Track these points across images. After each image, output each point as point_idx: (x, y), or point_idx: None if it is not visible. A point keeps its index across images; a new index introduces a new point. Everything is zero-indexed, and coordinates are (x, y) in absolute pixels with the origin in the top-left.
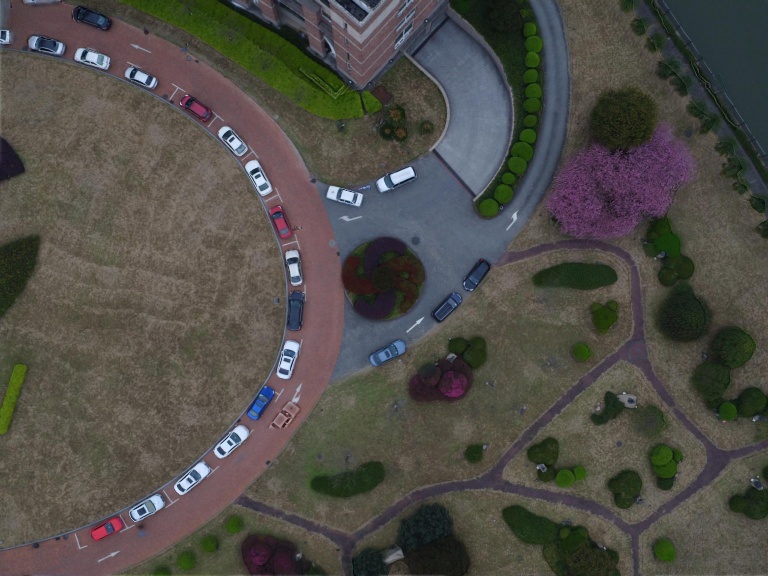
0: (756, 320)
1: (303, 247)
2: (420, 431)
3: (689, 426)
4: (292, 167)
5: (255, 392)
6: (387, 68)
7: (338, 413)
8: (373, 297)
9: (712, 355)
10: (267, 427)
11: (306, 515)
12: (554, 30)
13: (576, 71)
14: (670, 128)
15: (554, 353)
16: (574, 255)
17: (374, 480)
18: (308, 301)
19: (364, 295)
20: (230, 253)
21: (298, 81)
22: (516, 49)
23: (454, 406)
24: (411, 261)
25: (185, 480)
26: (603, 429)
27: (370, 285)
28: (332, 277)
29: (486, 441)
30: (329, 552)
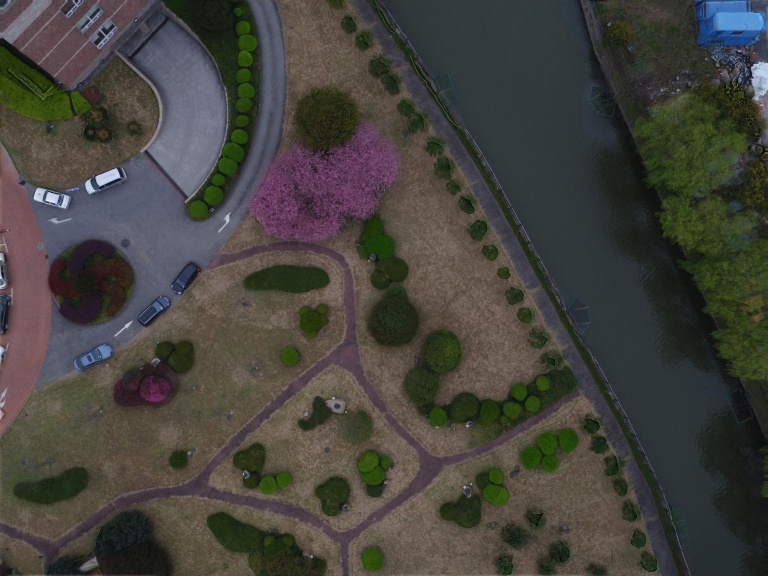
0: (472, 323)
1: (11, 250)
2: (125, 436)
3: (401, 432)
4: (1, 169)
5: None
6: (100, 68)
7: (43, 418)
8: (79, 300)
9: (421, 359)
10: None
11: (9, 521)
12: (272, 29)
13: (293, 70)
14: (388, 128)
15: (263, 357)
16: (286, 257)
17: (74, 486)
18: (15, 304)
19: (70, 298)
20: None
21: (7, 82)
22: (230, 48)
23: (160, 411)
24: (118, 264)
25: None
26: (311, 435)
27: (73, 288)
28: (40, 280)
29: (192, 447)
30: (31, 559)
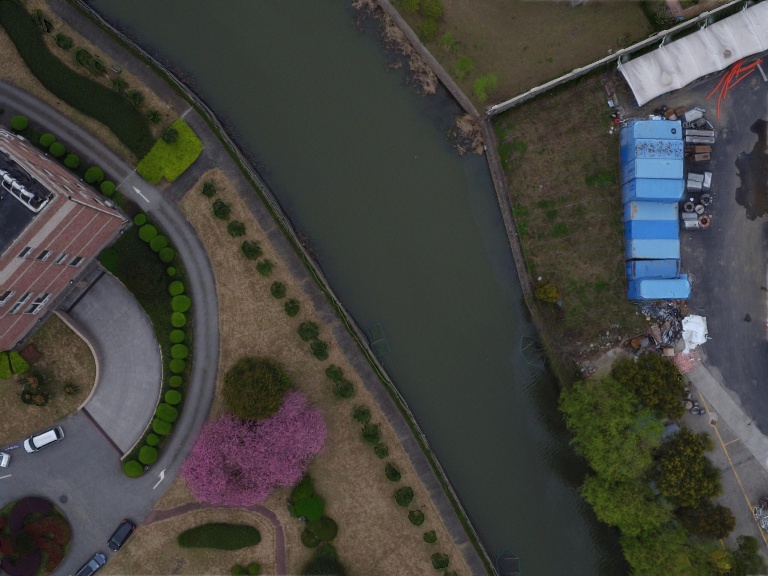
0: None
1: None
2: None
3: None
4: None
5: None
6: (38, 326)
7: None
8: (18, 557)
9: None
10: None
11: None
12: (206, 286)
13: (226, 327)
14: (319, 386)
15: None
16: (219, 515)
17: None
18: None
19: (11, 554)
20: None
21: None
22: (164, 308)
23: None
24: (55, 522)
25: None
26: None
27: None
28: None
29: None
30: None
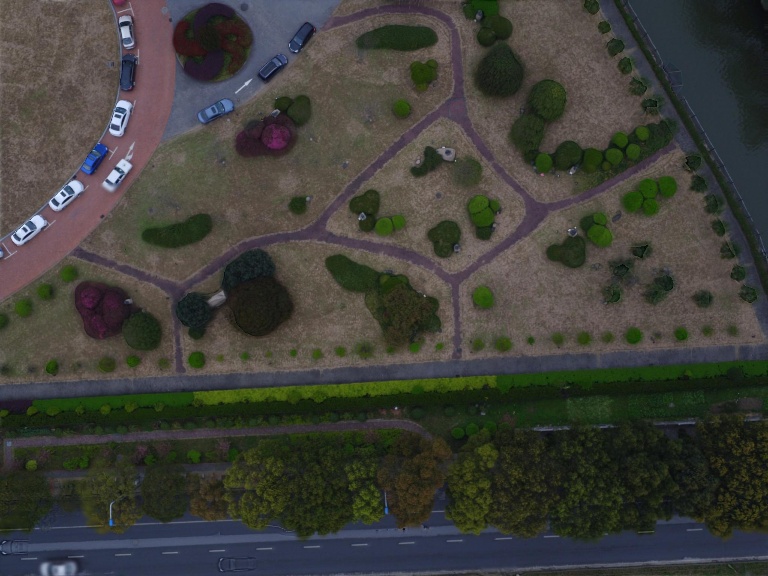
0: (574, 78)
1: (137, 14)
2: (247, 185)
3: (508, 180)
4: None
5: (90, 150)
6: None
7: (169, 169)
8: (202, 59)
9: (527, 108)
10: (101, 183)
11: (137, 265)
12: None
13: None
14: None
15: (376, 111)
16: (397, 19)
17: (200, 229)
18: (141, 64)
19: (194, 57)
20: (68, 20)
21: None
22: None
23: (280, 162)
24: (238, 24)
25: (20, 229)
26: (423, 182)
27: (198, 45)
28: (164, 42)
29: (310, 194)
30: (159, 300)
